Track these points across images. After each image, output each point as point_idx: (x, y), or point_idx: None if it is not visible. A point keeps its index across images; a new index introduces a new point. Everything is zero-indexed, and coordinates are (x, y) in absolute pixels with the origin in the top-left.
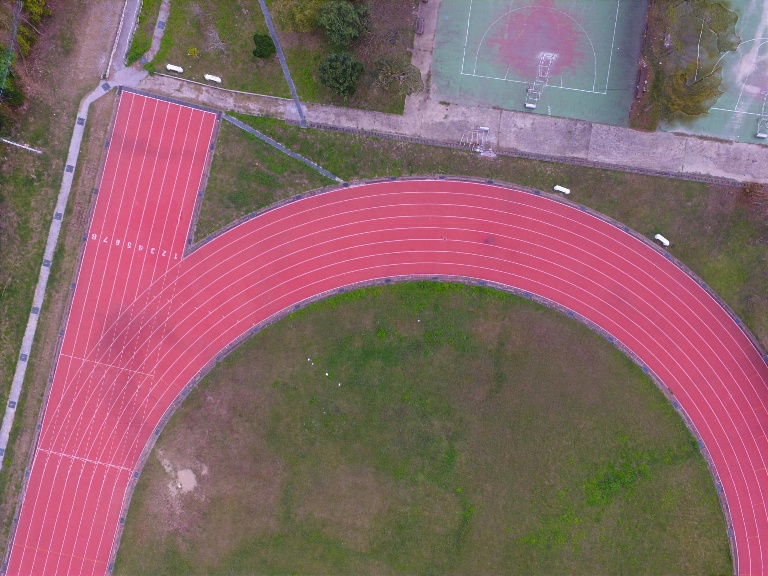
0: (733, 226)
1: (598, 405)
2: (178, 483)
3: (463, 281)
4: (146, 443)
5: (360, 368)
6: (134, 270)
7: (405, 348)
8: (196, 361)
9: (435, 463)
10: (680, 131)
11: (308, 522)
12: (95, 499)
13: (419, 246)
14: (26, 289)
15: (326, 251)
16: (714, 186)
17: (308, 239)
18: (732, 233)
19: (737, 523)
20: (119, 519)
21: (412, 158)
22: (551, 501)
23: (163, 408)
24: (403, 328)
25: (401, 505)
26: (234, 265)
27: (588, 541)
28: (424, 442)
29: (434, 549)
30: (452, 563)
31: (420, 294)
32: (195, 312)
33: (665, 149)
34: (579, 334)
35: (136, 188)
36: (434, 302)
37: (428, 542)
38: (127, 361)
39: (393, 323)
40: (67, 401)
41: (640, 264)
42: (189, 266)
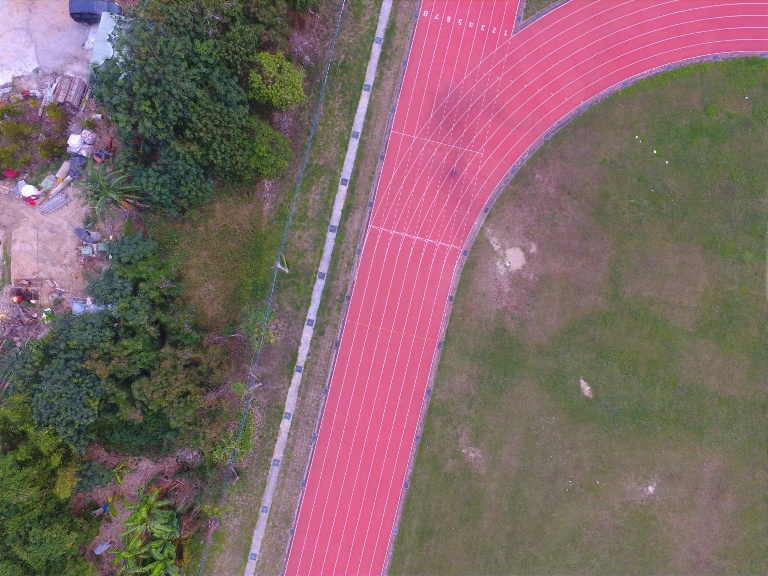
0: None
1: None
2: (506, 261)
3: None
4: (475, 221)
5: (687, 146)
6: (464, 47)
7: (733, 125)
8: (525, 139)
9: (763, 241)
10: None
11: (636, 300)
12: (425, 277)
13: (748, 22)
14: (359, 66)
15: (654, 28)
16: None
17: (636, 16)
18: None
19: None
20: (448, 297)
21: None
22: None
23: (492, 186)
24: (730, 105)
25: (728, 284)
26: (563, 42)
27: None
28: (751, 220)
29: (761, 327)
30: None
31: (748, 70)
32: (524, 89)
33: None
34: None
35: None
36: (762, 79)
37: (755, 321)
38: (457, 139)
39: (721, 100)
40: (398, 178)
41: None
42: (519, 43)
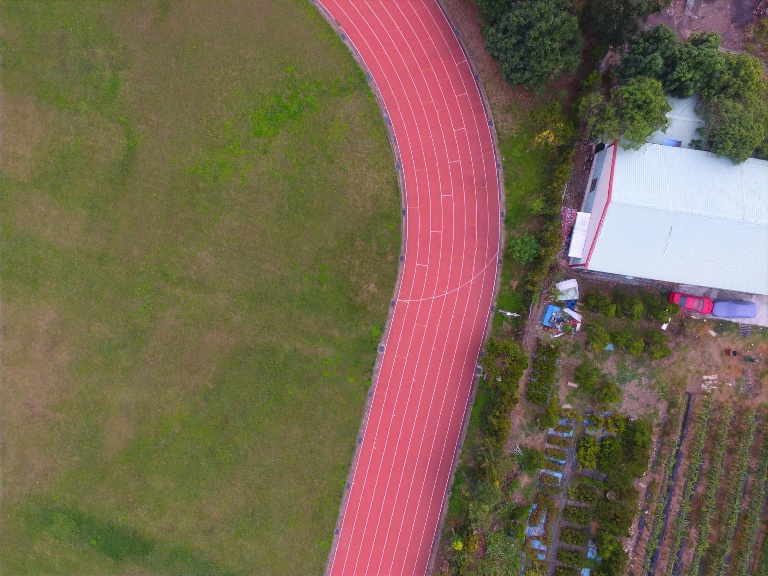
0: None
1: (264, 35)
2: None
3: None
4: None
5: None
6: None
7: None
8: None
9: (98, 91)
10: None
11: None
12: None
13: None
14: None
15: None
16: None
17: None
18: None
19: (405, 156)
20: None
21: None
22: (217, 132)
23: None
24: None
25: (64, 134)
26: None
27: (255, 173)
28: (87, 70)
29: (98, 179)
30: (116, 193)
31: None
32: None
33: None
34: None
35: None
36: None
37: (92, 172)
38: None
39: None
40: None
41: None
42: None
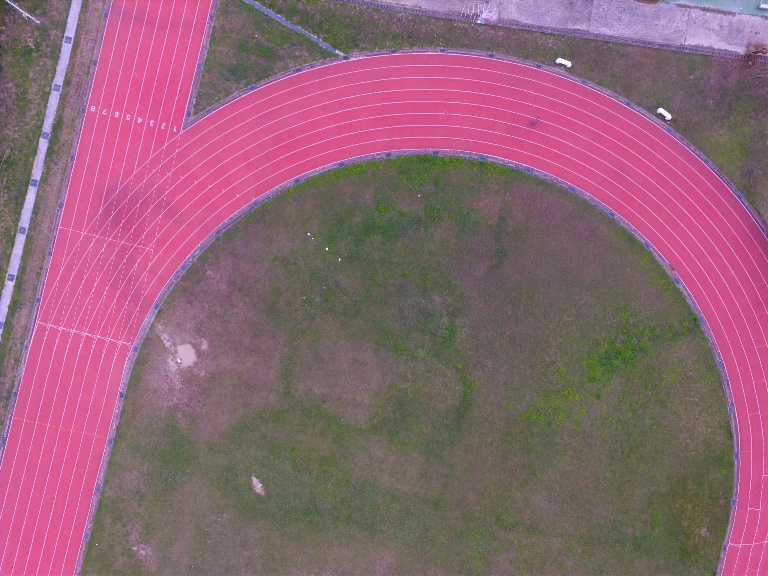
0: (735, 100)
1: (599, 281)
2: (178, 358)
3: (464, 156)
4: (145, 317)
5: (360, 243)
6: (133, 143)
7: (405, 223)
8: (196, 235)
9: (435, 339)
10: (683, 3)
11: (308, 397)
12: (94, 373)
13: (420, 120)
14: (25, 161)
15: (326, 125)
16: (717, 59)
17: (308, 112)
18: (734, 107)
19: (738, 400)
20: (119, 394)
21: (413, 30)
22: (552, 377)
23: (162, 282)
24: (403, 203)
25: (401, 381)
26: (234, 138)
27: (589, 418)
28: (424, 318)
29: (434, 425)
30: (452, 439)
31: (421, 168)
32: (194, 186)
33: (667, 21)
34: (580, 209)
35: (135, 60)
36: (435, 177)
37: (428, 418)
38: (126, 235)
39: (393, 198)
40: (66, 274)
41: (642, 139)
42: (188, 139)
